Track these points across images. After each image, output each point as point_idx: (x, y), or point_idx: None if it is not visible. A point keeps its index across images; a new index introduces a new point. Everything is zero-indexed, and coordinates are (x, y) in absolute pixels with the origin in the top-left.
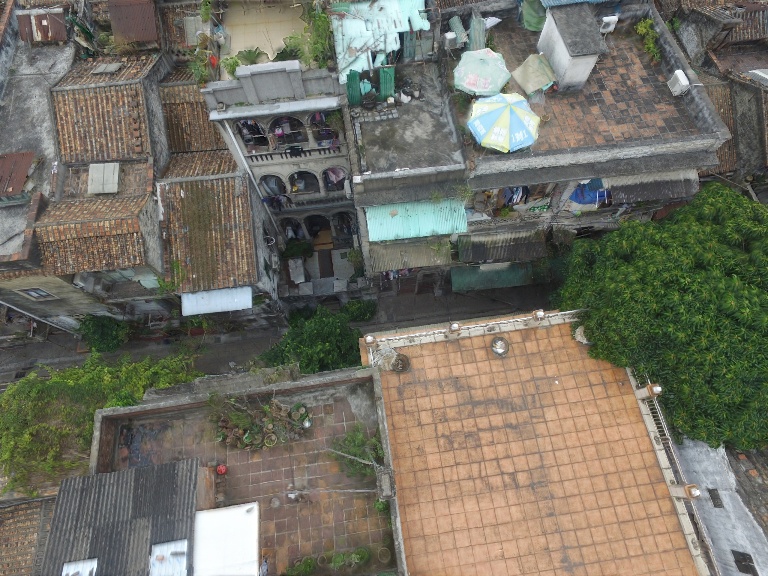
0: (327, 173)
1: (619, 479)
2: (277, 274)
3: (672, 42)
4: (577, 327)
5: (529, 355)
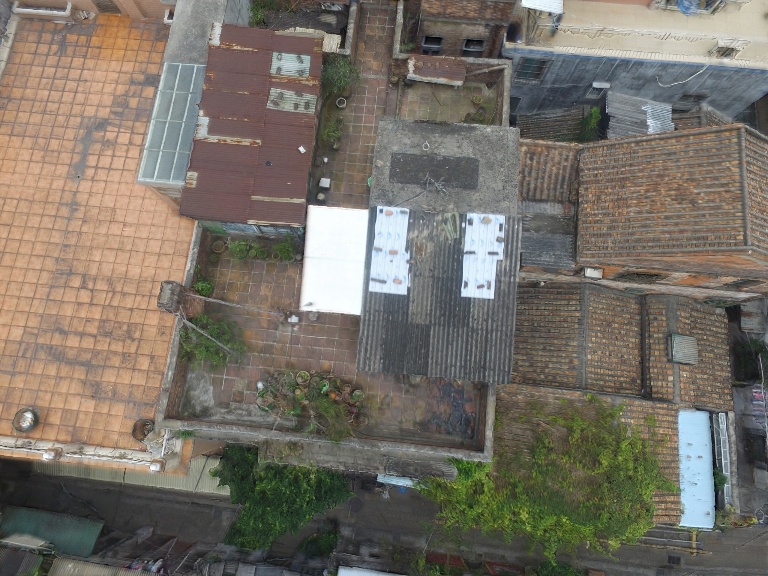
0: None
1: None
2: None
3: None
4: None
5: (3, 402)
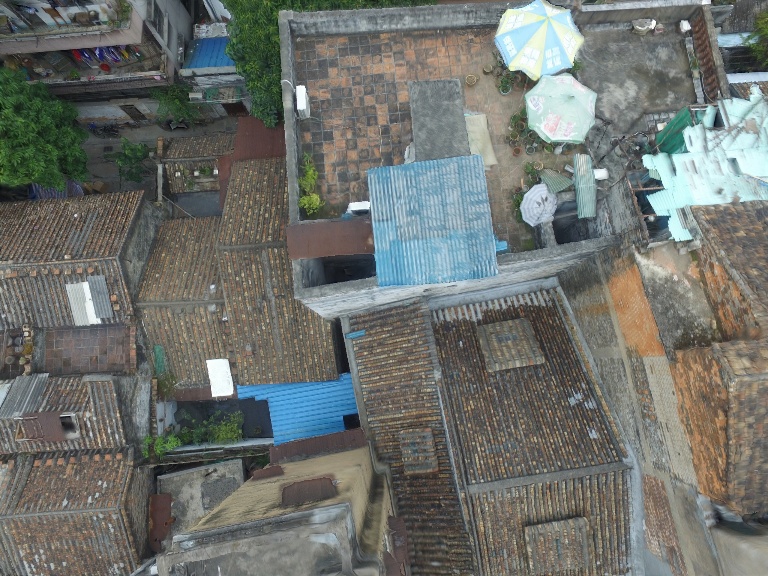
0: None
1: None
2: None
3: (292, 155)
4: None
5: None
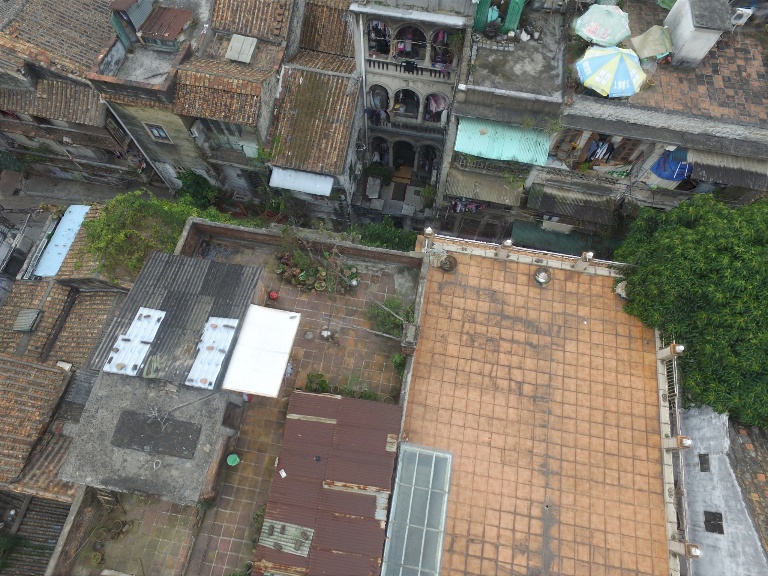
0: (429, 101)
1: (617, 419)
2: (356, 185)
3: None
4: (620, 281)
5: (567, 293)
